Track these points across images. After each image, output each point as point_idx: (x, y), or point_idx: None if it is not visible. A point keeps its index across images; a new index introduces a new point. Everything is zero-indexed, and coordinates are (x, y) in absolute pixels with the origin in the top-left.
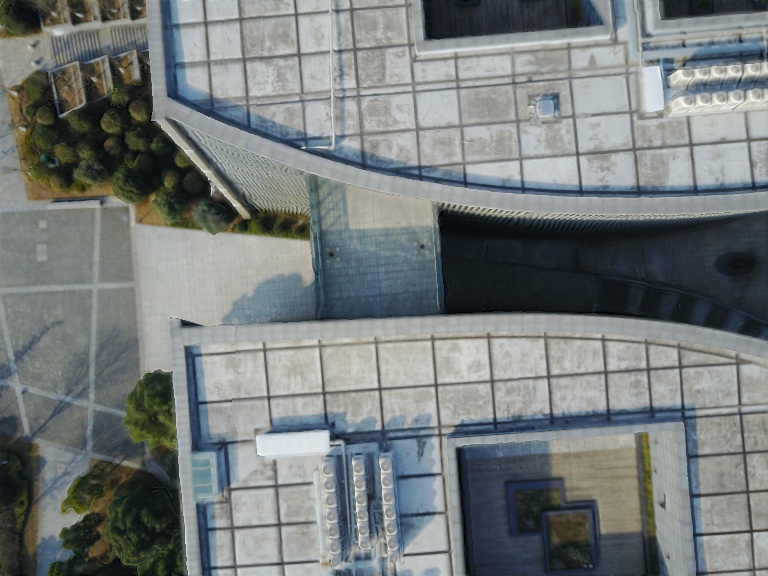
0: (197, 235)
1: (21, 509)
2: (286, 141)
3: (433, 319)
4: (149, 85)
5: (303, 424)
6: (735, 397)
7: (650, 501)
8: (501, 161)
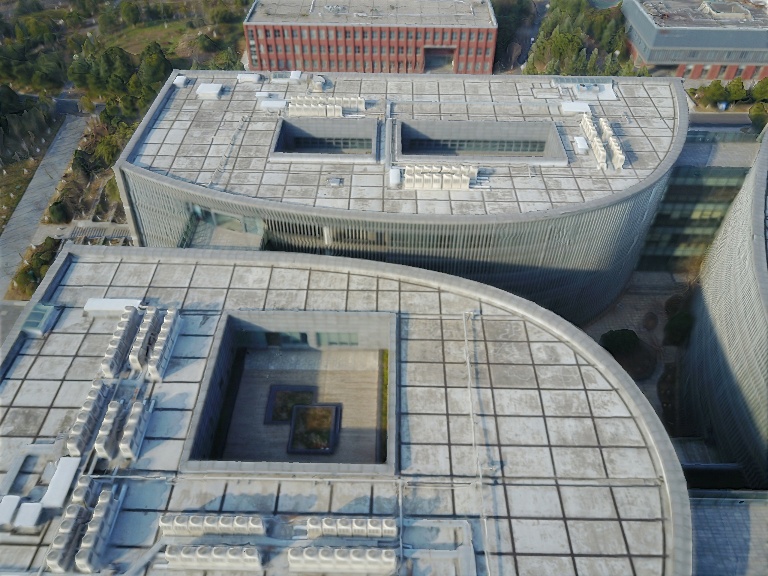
0: None
1: None
2: None
3: (237, 251)
4: None
5: None
6: (437, 310)
7: (385, 404)
8: (304, 198)
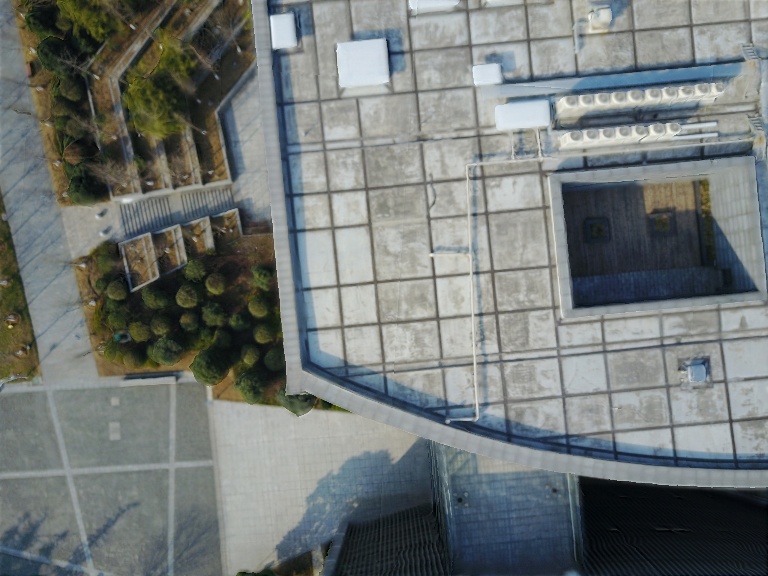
0: (278, 411)
1: None
2: (426, 410)
3: None
4: (224, 255)
5: None
6: None
7: None
8: (651, 429)
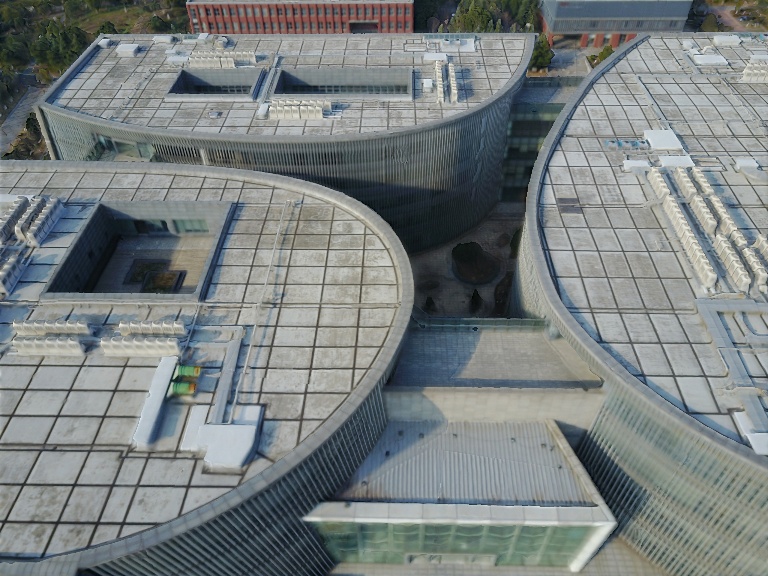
0: None
1: None
2: None
3: (119, 162)
4: None
5: None
6: None
7: None
8: None
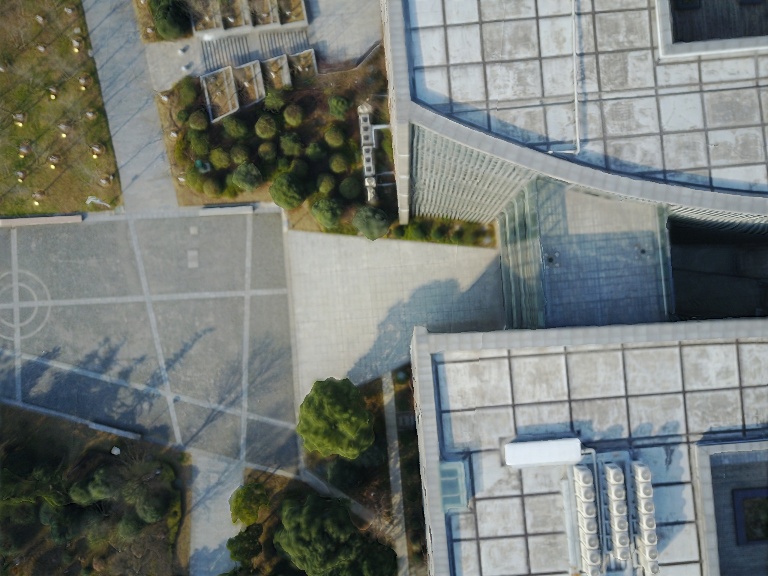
0: (351, 241)
1: (175, 520)
2: (528, 146)
3: (685, 325)
4: (301, 90)
5: (548, 432)
6: None
7: None
8: (747, 165)
